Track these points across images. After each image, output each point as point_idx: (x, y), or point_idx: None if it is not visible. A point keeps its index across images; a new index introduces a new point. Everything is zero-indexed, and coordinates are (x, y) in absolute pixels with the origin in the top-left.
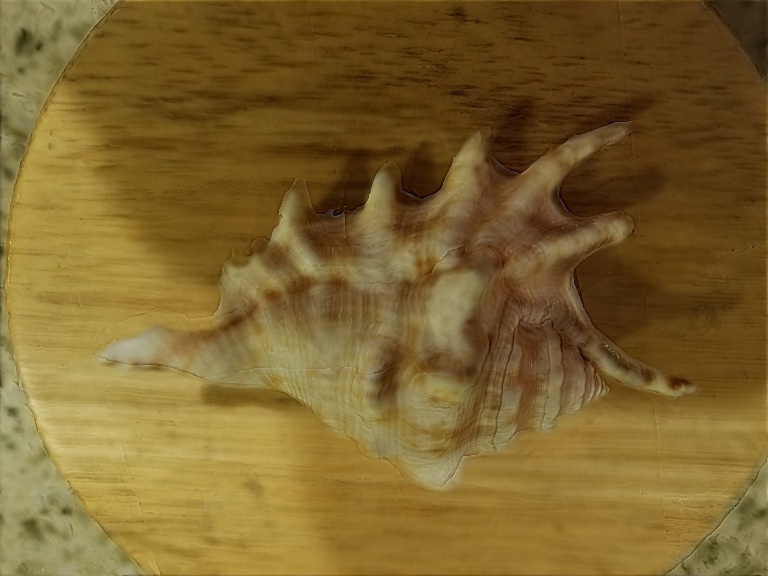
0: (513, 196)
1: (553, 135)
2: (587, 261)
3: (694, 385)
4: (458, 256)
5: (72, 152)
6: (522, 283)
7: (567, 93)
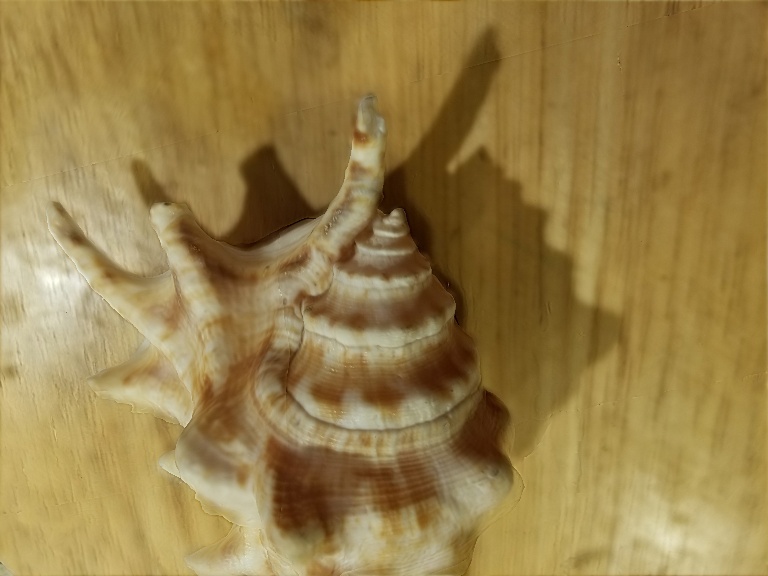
0: None
1: (116, 260)
2: (262, 200)
3: None
4: None
5: None
6: (251, 350)
7: None
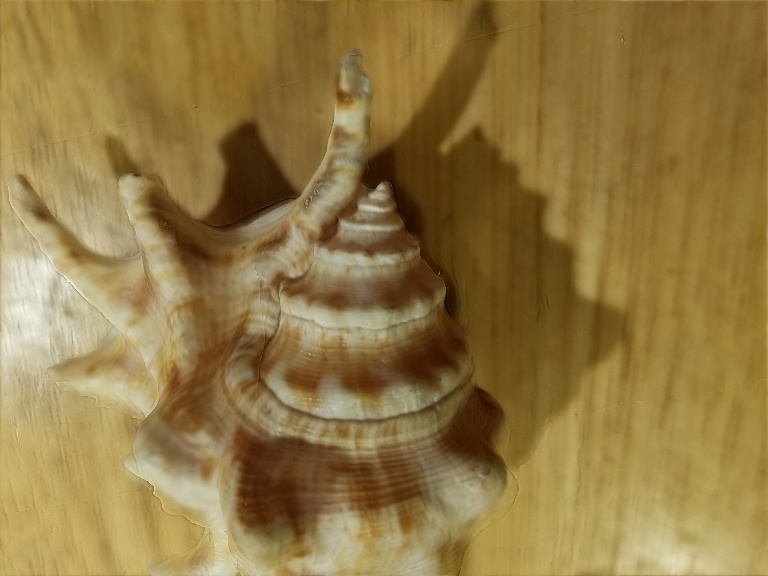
0: None
1: None
2: (242, 181)
3: None
4: None
5: None
6: (223, 336)
7: None
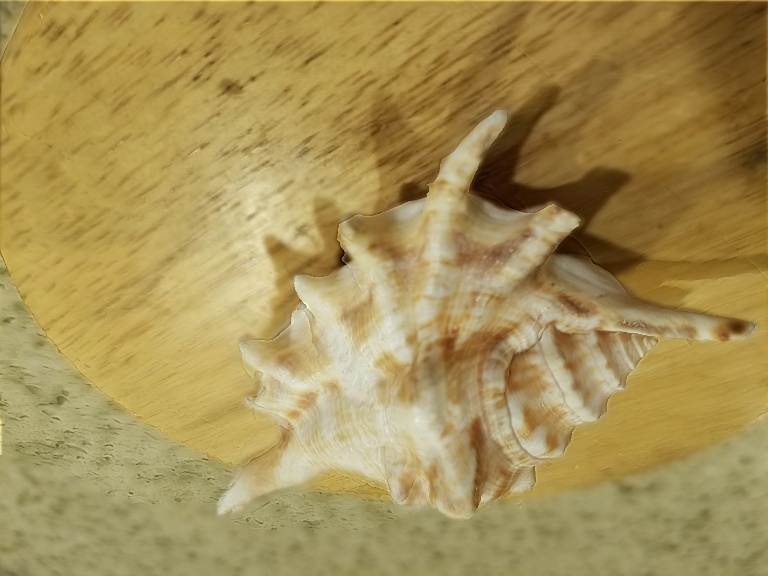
0: (425, 259)
1: (434, 120)
2: (571, 197)
3: (745, 328)
4: (400, 393)
5: (102, 362)
6: (492, 328)
7: (412, 71)
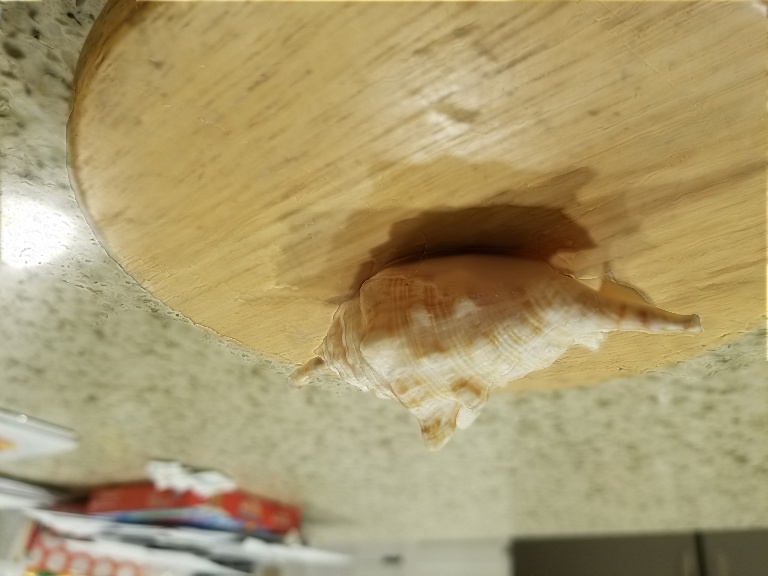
0: None
1: None
2: None
3: None
4: None
5: None
6: None
7: None
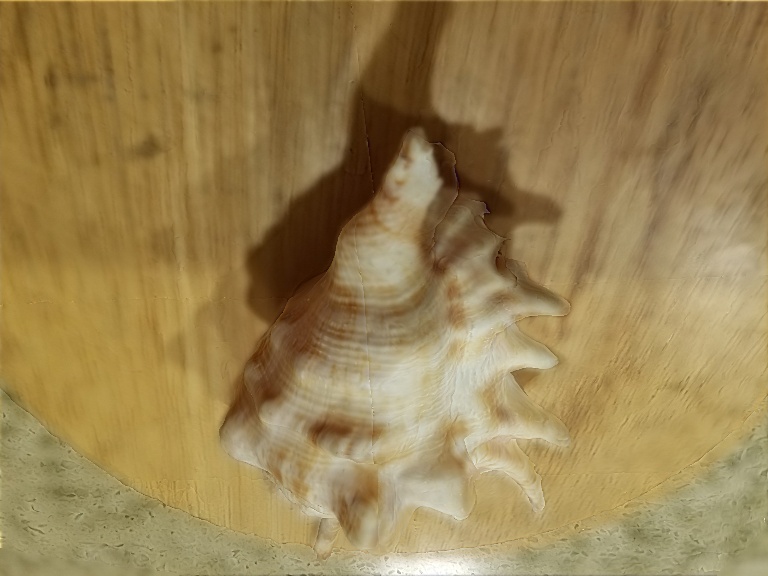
0: (503, 454)
1: None
2: None
3: None
4: None
5: None
6: None
7: None
